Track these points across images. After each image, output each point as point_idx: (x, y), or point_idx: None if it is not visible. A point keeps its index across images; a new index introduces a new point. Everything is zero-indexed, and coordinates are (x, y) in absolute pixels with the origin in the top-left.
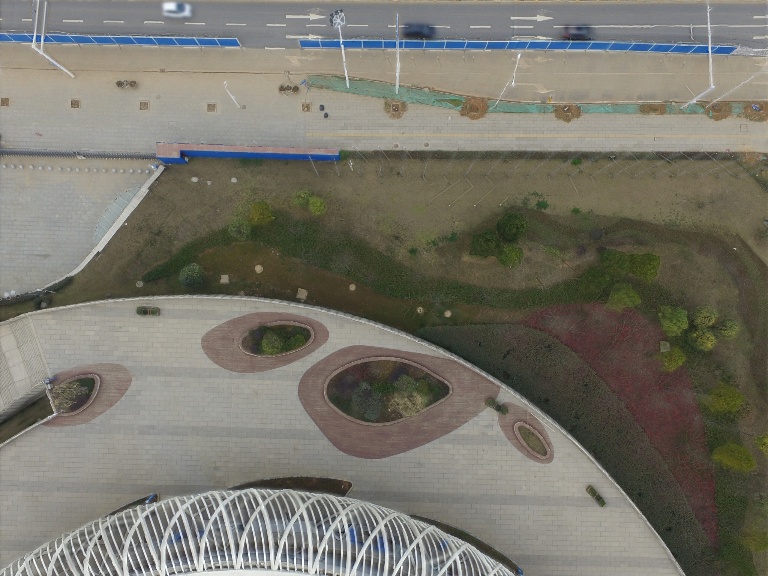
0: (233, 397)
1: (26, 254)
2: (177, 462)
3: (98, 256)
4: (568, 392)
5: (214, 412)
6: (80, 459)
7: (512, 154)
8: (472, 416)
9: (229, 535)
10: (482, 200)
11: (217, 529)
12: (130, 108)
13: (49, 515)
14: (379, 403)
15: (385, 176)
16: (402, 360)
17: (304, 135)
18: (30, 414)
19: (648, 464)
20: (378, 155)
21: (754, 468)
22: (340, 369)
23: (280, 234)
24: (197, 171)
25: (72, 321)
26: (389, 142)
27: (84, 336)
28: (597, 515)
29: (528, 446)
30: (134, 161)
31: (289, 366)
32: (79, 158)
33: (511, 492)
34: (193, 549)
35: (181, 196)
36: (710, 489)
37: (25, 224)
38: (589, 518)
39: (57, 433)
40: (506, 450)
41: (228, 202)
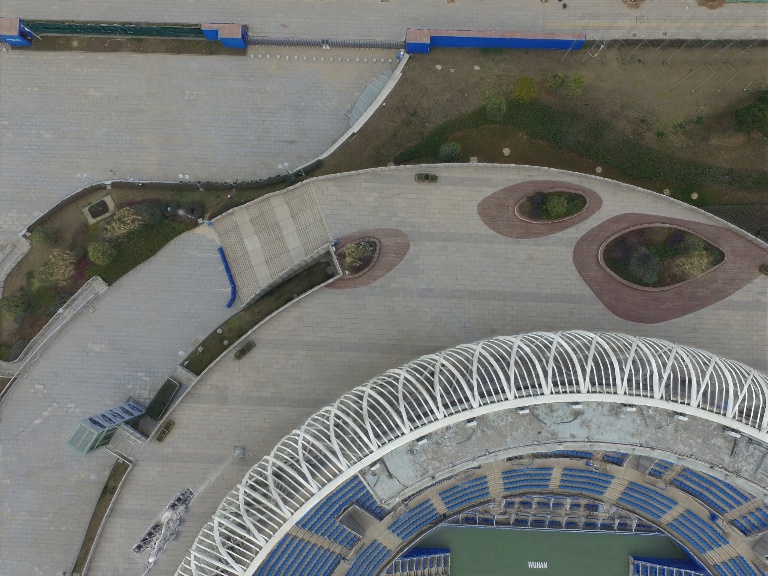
0: (509, 262)
1: (273, 140)
2: (455, 324)
3: (352, 137)
4: None
5: (491, 276)
6: (361, 320)
7: (751, 42)
8: (746, 283)
9: (575, 360)
10: (726, 85)
11: (562, 355)
12: (371, 0)
13: (332, 374)
14: (657, 267)
15: (626, 63)
16: (677, 227)
17: (543, 25)
18: (286, 290)
19: None
20: (617, 44)
21: None
22: (616, 235)
23: (528, 117)
24: (439, 60)
25: (352, 188)
26: (627, 31)
27: (364, 202)
28: None
29: None
30: (376, 51)
31: (564, 232)
32: (323, 48)
33: None
34: (542, 373)
35: (430, 81)
36: None
37: (272, 111)
38: None
39: (339, 295)
40: None
41: (475, 87)
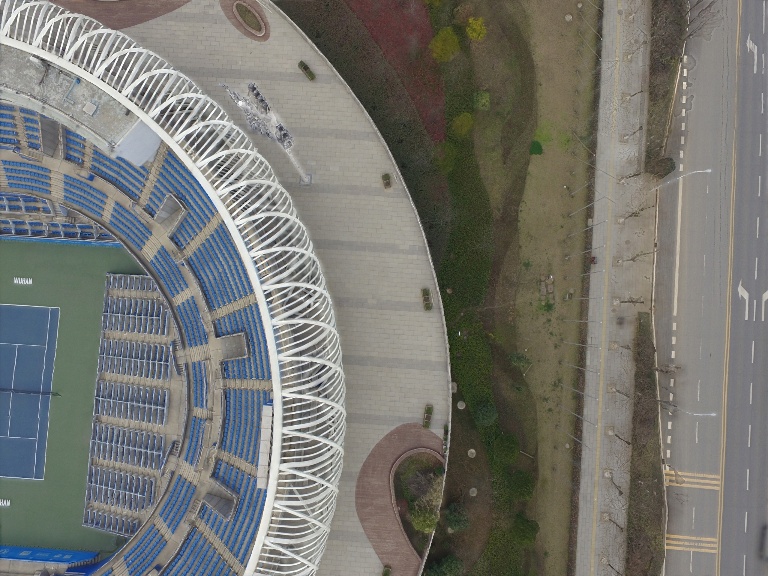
0: None
1: None
2: None
3: None
4: (310, 11)
5: None
6: None
7: None
8: None
9: None
10: None
11: None
12: None
13: None
14: None
15: None
16: None
17: None
18: None
19: (382, 77)
20: None
21: (483, 83)
22: None
23: None
24: None
25: None
26: None
27: None
28: (308, 90)
29: (244, 22)
30: None
31: None
32: None
33: (227, 66)
34: None
35: None
36: (441, 103)
37: None
38: (300, 93)
39: None
40: (225, 28)
41: None
